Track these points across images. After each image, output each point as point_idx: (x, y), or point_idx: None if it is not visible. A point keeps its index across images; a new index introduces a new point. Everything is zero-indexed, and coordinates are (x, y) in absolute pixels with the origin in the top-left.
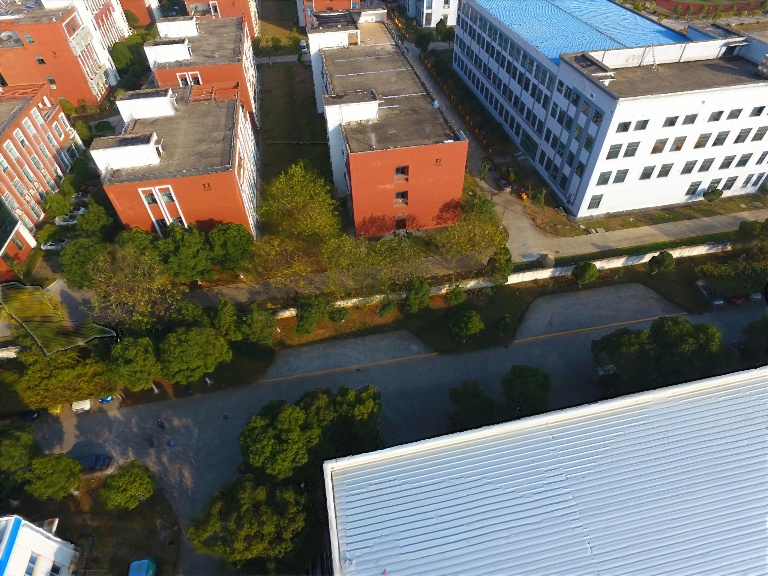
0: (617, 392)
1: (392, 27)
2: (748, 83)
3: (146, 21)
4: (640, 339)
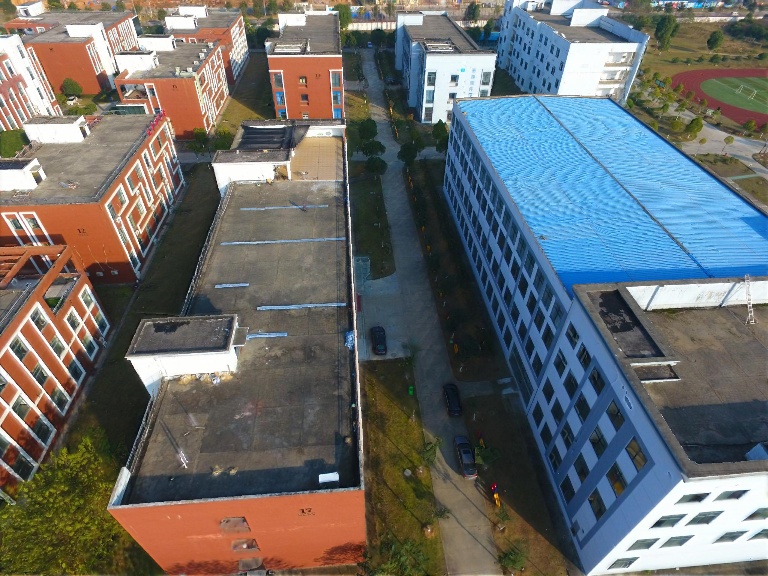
0: None
1: (384, 119)
2: None
3: (96, 90)
4: None
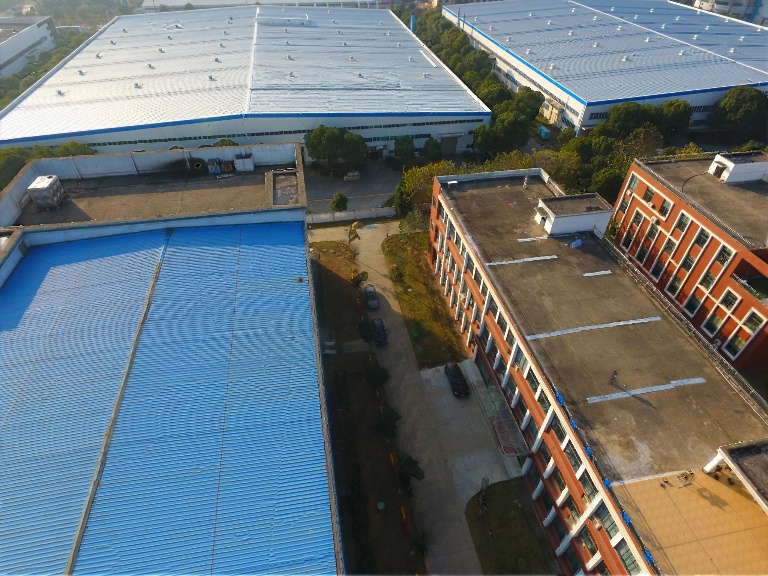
0: (353, 167)
1: None
2: (152, 151)
3: None
4: None
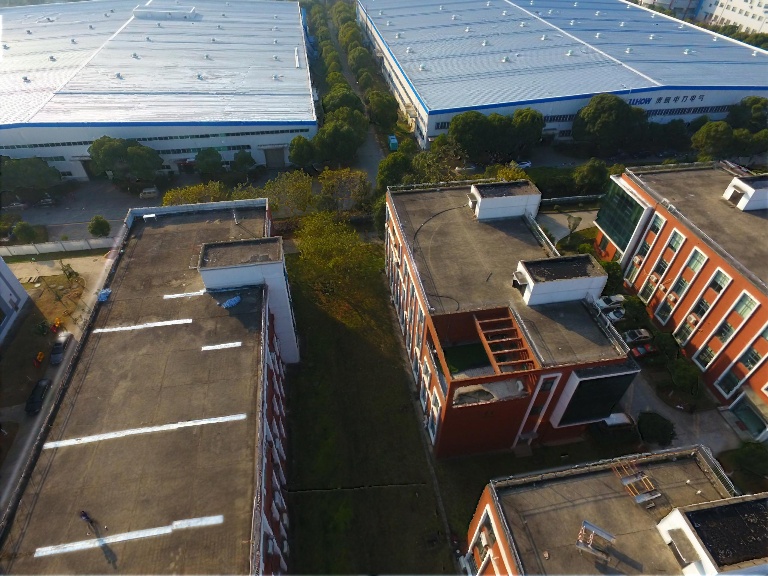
0: (155, 182)
1: None
2: None
3: None
4: (136, 149)
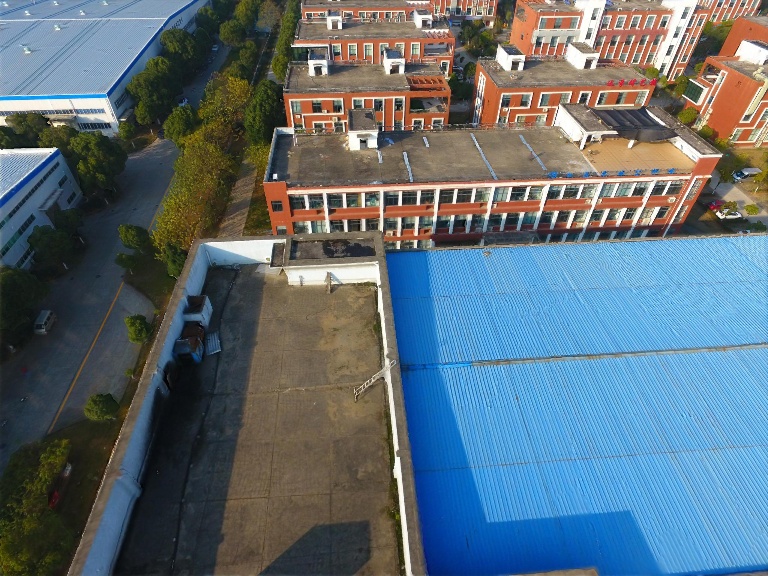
0: None
1: None
2: (126, 430)
3: None
4: None
